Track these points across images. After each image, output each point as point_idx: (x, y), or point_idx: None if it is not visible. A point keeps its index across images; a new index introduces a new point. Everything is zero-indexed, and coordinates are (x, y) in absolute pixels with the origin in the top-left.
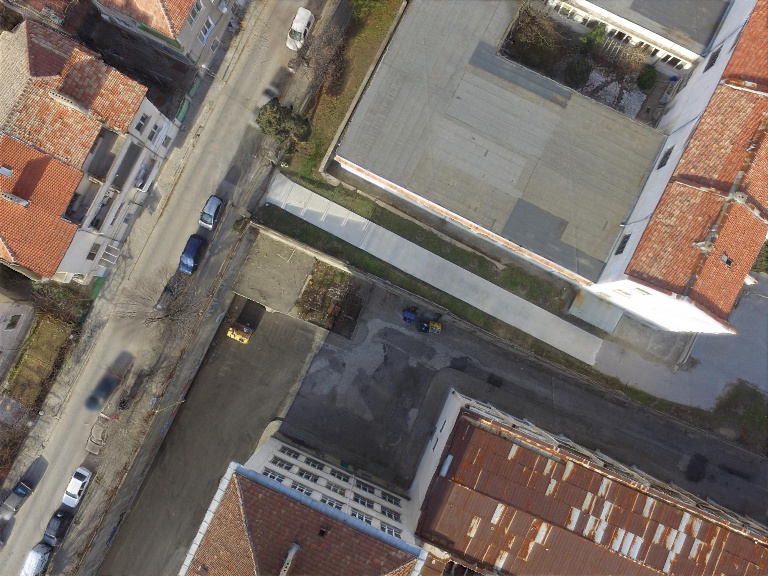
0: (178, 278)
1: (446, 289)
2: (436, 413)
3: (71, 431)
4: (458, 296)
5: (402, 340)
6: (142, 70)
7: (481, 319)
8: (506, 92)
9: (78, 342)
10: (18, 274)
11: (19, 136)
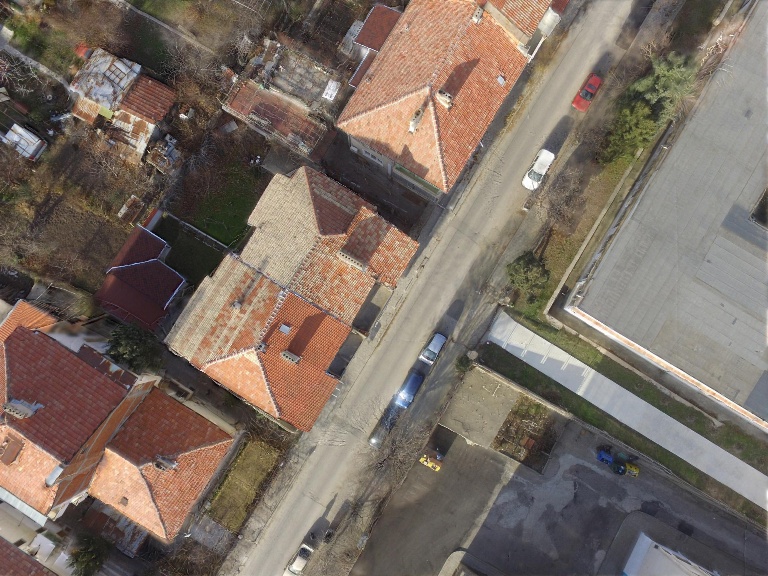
0: (392, 411)
1: (660, 442)
2: (624, 557)
3: (269, 557)
4: (672, 450)
5: (593, 478)
6: (375, 198)
7: (694, 476)
8: (757, 259)
9: (284, 467)
10: (240, 400)
11: (302, 294)
